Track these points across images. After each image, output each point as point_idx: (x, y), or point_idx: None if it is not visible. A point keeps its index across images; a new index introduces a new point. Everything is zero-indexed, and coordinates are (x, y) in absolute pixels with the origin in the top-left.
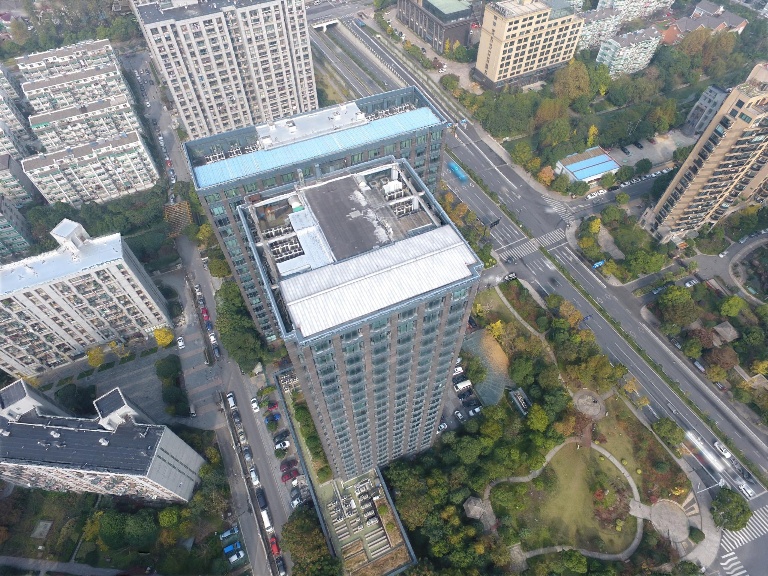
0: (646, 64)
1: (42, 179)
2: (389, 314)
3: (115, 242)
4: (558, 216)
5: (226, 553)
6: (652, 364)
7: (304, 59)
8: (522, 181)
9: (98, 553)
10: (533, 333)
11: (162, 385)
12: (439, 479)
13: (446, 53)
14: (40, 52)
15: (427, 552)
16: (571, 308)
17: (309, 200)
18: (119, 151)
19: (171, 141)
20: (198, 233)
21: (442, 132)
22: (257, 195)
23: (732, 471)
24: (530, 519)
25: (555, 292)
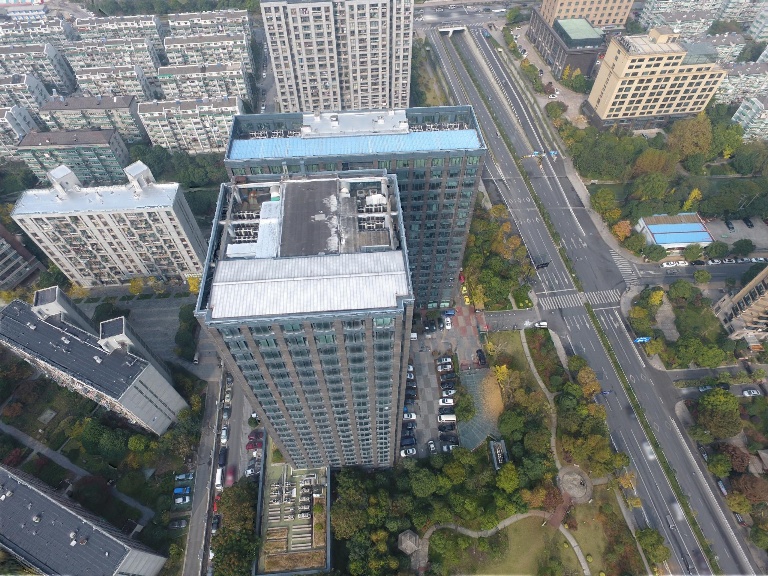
0: None
1: (150, 122)
2: (300, 321)
3: (172, 191)
4: (620, 276)
5: (175, 493)
6: (665, 466)
7: (403, 59)
8: (594, 229)
9: (79, 452)
10: (543, 390)
11: (179, 327)
12: (382, 500)
13: (564, 79)
14: (189, 13)
15: (346, 566)
16: (591, 376)
17: (287, 193)
18: (218, 112)
19: None
20: None
21: (480, 158)
22: (243, 177)
23: None
24: None
25: (584, 355)
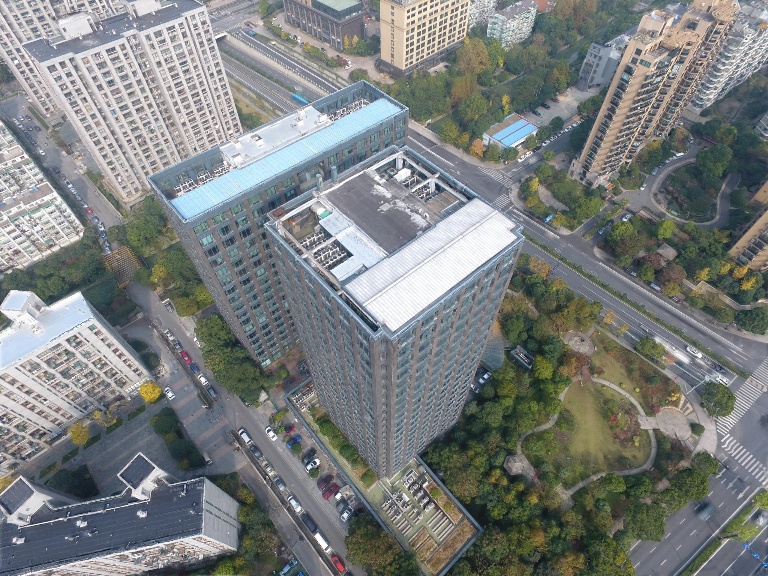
0: (529, 33)
1: None
2: (459, 291)
3: (78, 303)
4: (498, 183)
5: None
6: (618, 295)
7: (217, 75)
8: (456, 158)
9: None
10: (511, 294)
11: (165, 442)
12: (477, 448)
13: (346, 49)
14: None
15: (486, 519)
16: (539, 262)
17: (334, 203)
18: (33, 208)
19: (83, 187)
20: (151, 276)
21: (405, 120)
22: (280, 209)
23: (707, 368)
24: (563, 460)
25: None
